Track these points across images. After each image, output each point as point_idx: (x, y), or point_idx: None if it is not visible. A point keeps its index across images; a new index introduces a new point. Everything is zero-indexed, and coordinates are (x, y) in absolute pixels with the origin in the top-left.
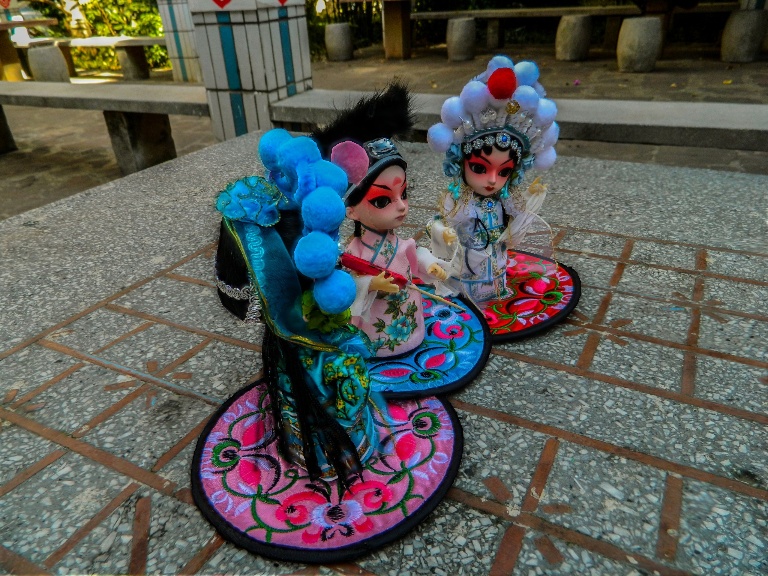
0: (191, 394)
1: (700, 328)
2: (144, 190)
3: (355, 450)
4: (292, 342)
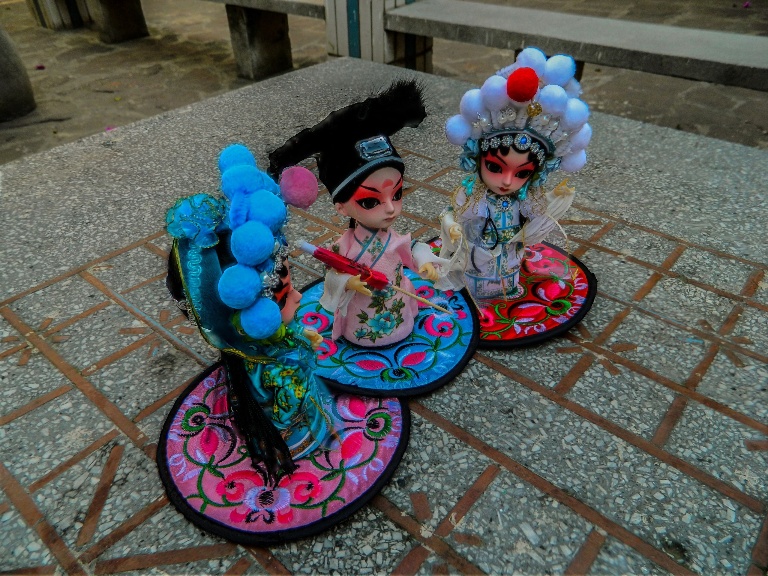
0: (187, 351)
1: (709, 369)
2: (215, 118)
3: (287, 449)
4: (227, 352)
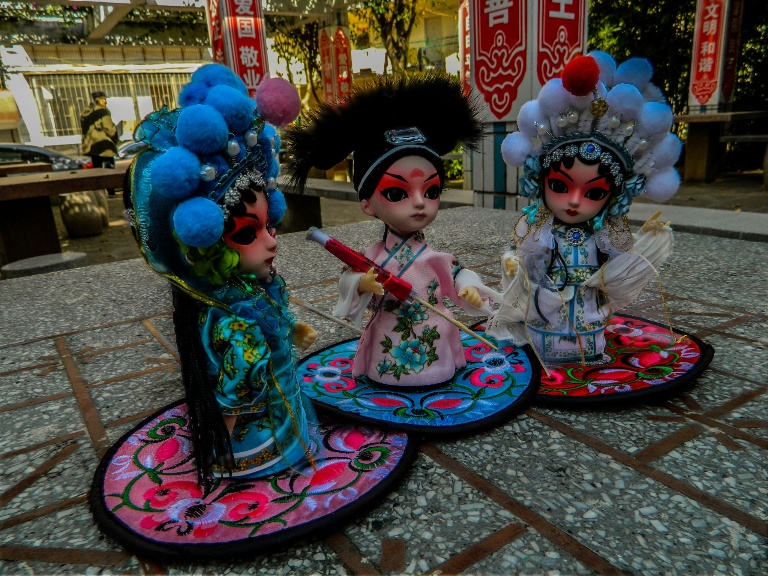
0: None
1: None
2: None
3: (227, 437)
4: None
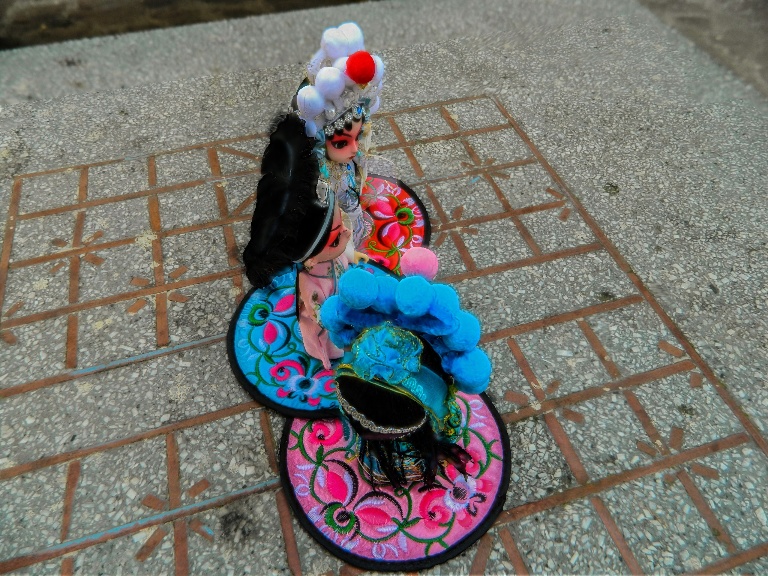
0: (233, 497)
1: (502, 191)
2: None
3: None
4: None
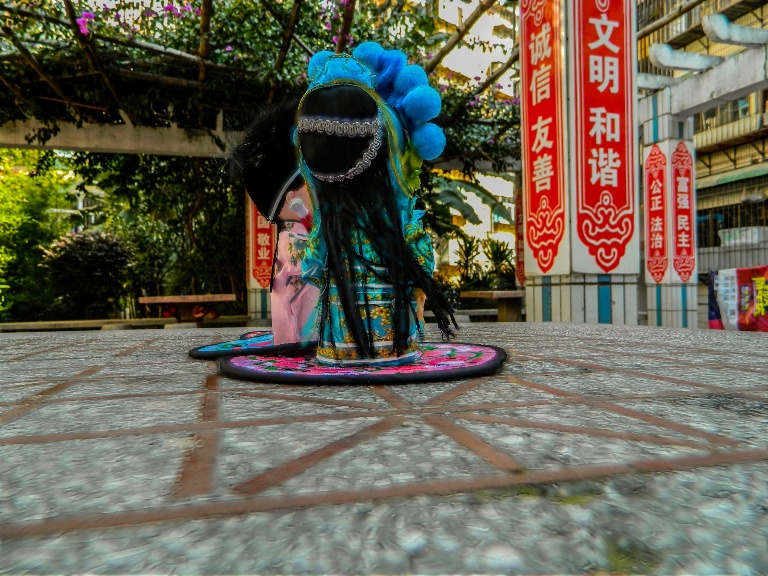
0: (155, 375)
1: None
2: None
3: None
4: (398, 185)
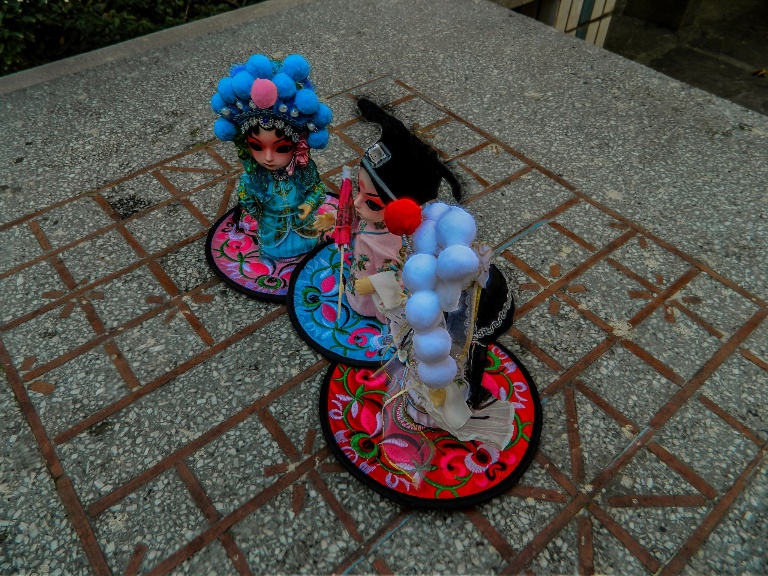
0: None
1: None
2: None
3: (238, 216)
4: None
